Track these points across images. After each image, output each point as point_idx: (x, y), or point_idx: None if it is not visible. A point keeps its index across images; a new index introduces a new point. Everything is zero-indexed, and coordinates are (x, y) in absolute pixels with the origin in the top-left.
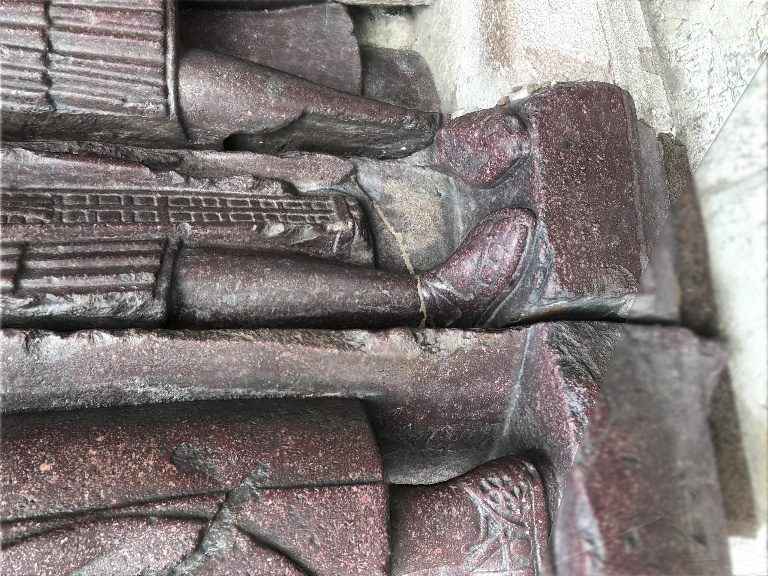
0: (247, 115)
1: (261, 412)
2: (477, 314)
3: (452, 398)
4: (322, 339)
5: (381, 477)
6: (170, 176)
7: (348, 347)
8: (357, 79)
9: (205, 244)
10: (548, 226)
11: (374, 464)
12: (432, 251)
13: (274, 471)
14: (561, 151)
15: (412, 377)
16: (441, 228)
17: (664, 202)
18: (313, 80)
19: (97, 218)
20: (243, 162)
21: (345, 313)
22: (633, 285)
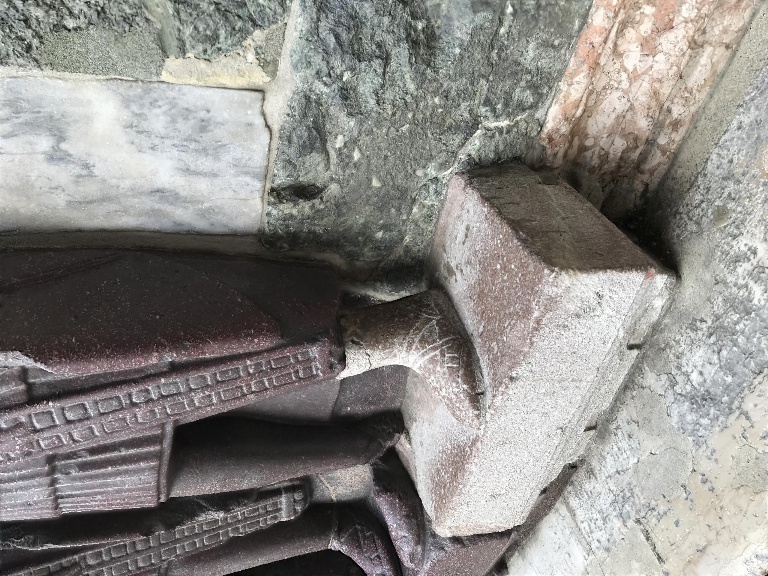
0: None
1: None
2: None
3: None
4: None
5: None
6: None
7: None
8: (331, 403)
9: None
10: None
11: None
12: (353, 493)
13: None
14: (440, 573)
15: None
16: (365, 483)
17: None
18: (290, 407)
19: (112, 572)
20: None
21: None
22: None
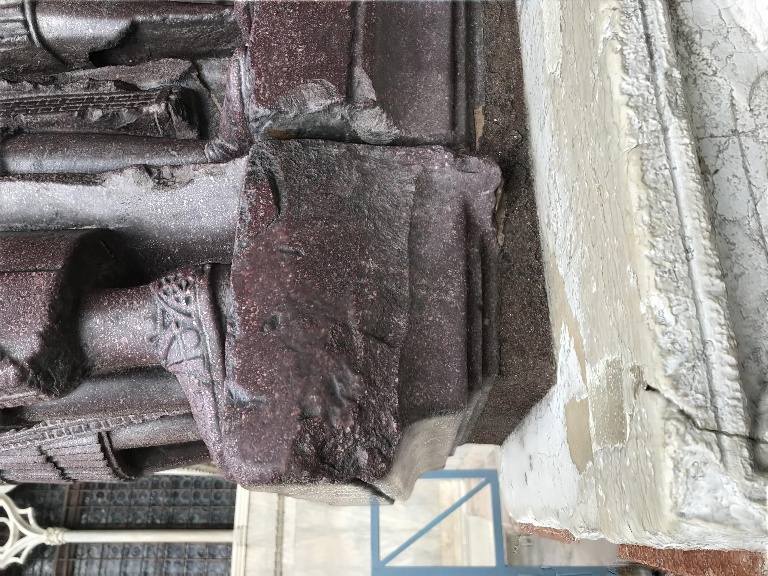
0: (90, 33)
1: None
2: None
3: (198, 230)
4: (74, 179)
5: (60, 267)
6: (24, 85)
7: (92, 183)
8: None
9: (41, 131)
10: (252, 54)
11: (60, 259)
12: None
13: None
14: None
15: (152, 209)
16: None
17: (446, 29)
18: None
19: None
20: (100, 74)
21: None
22: (334, 96)
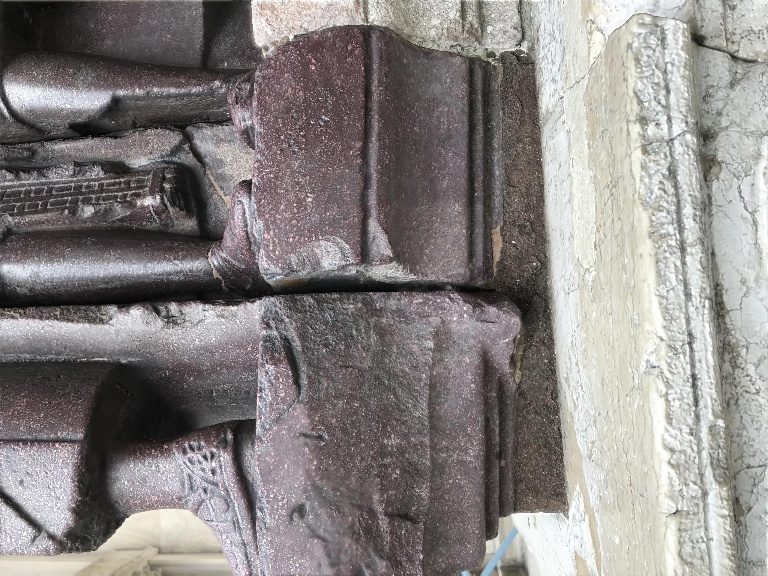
0: (67, 107)
1: (23, 376)
2: (263, 279)
3: (212, 363)
4: (79, 314)
5: (83, 437)
6: (4, 173)
7: (98, 321)
8: (199, 43)
9: (31, 229)
10: (257, 201)
11: (81, 425)
12: None
13: (4, 426)
14: (280, 117)
15: (164, 345)
16: None
17: (463, 146)
18: (158, 52)
19: None
20: (83, 147)
21: (142, 283)
22: (349, 257)
